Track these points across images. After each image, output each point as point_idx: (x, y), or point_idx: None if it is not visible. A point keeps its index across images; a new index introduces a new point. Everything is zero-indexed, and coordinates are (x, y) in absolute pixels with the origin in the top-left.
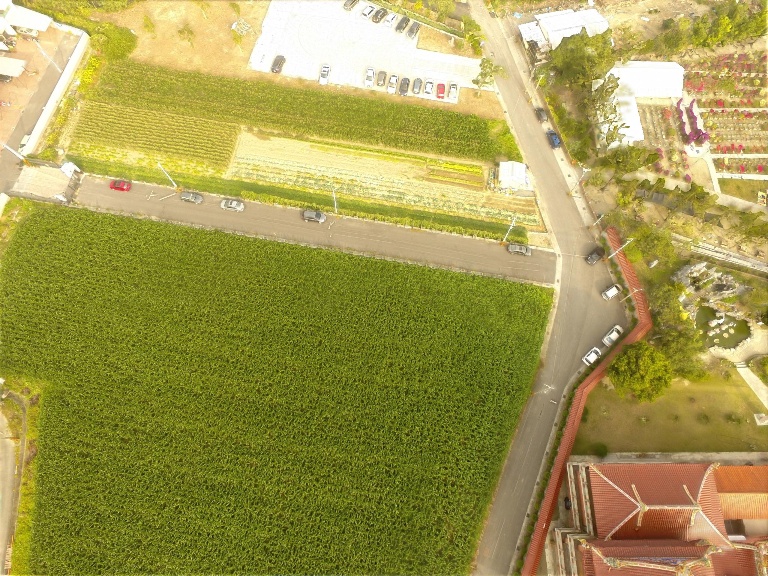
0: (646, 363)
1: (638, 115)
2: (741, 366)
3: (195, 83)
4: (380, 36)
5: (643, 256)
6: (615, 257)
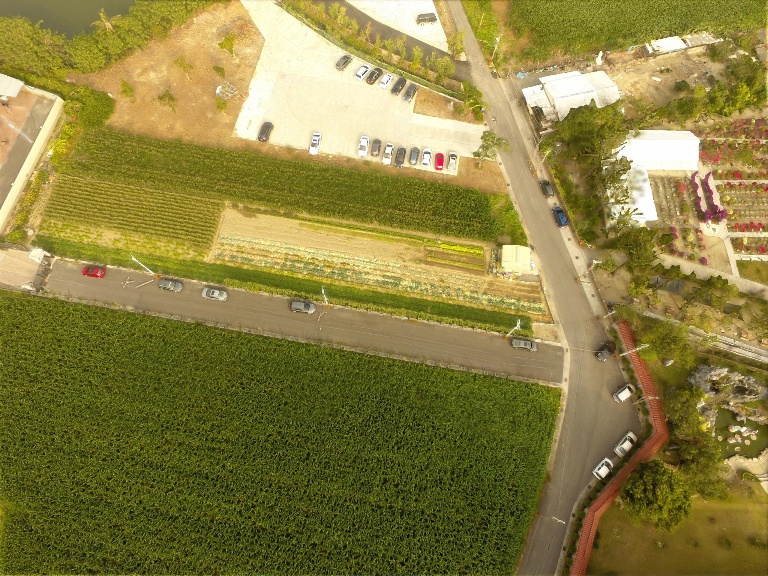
0: (664, 493)
1: (651, 192)
2: (765, 479)
3: (176, 154)
4: (375, 99)
5: (658, 356)
6: None
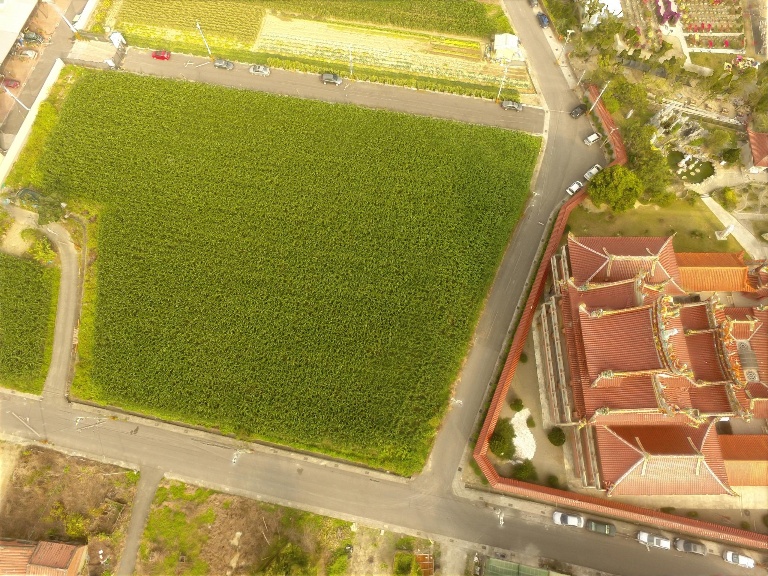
0: (619, 174)
1: None
2: (705, 196)
3: None
4: None
5: (620, 106)
6: (596, 111)
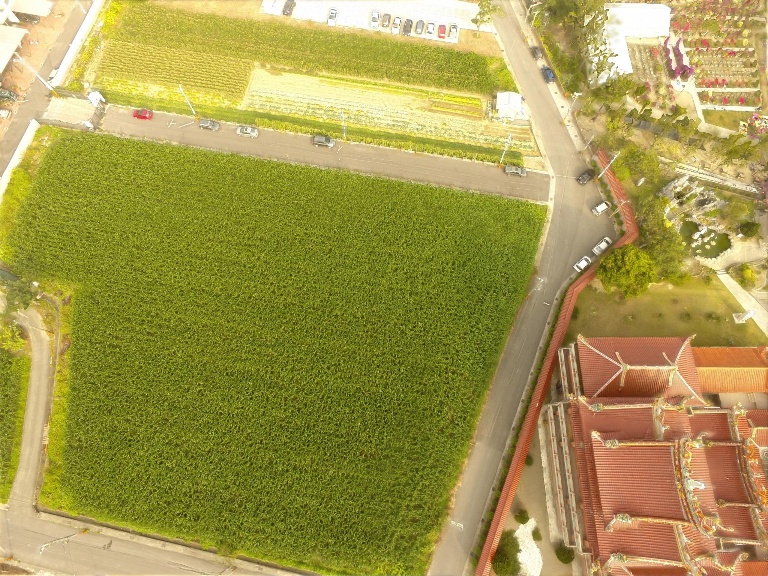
0: (631, 259)
1: (627, 51)
2: (721, 273)
3: (211, 23)
4: None
5: (630, 174)
6: (605, 177)
